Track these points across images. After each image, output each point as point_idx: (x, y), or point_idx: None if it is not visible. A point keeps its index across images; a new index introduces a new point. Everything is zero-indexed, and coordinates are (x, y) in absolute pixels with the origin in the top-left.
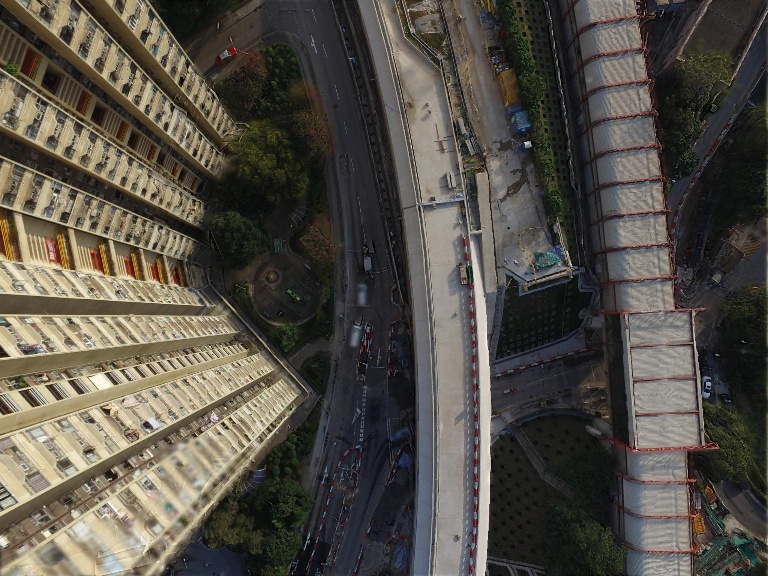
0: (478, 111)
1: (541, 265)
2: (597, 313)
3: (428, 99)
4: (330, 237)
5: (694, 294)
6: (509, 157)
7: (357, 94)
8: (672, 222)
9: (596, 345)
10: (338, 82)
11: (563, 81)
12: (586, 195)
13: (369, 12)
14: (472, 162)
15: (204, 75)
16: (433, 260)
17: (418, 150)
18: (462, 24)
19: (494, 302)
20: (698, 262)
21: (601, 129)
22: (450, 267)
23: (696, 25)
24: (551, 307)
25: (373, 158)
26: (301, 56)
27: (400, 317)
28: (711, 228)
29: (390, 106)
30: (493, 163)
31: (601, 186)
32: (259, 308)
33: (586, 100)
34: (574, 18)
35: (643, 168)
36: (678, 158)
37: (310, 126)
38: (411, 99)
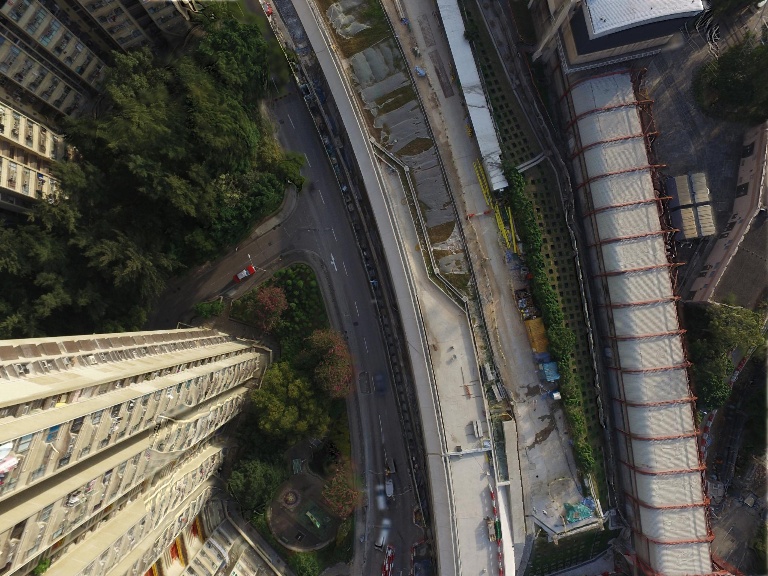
0: (504, 355)
1: (572, 520)
2: (628, 554)
3: (453, 341)
4: (350, 457)
5: (726, 513)
6: (537, 403)
7: (378, 317)
8: (702, 438)
9: (626, 570)
10: (358, 299)
11: (590, 312)
12: (615, 429)
13: (392, 249)
14: (499, 407)
15: (222, 291)
16: (460, 513)
17: (443, 395)
18: (487, 264)
19: (522, 549)
20: (729, 478)
21: (632, 379)
22: (477, 520)
23: (727, 264)
24: (580, 544)
25: (395, 381)
26: (321, 274)
27: (422, 538)
28: (742, 442)
29: (414, 346)
30: (520, 409)
31: (632, 436)
32: (277, 532)
33: (615, 342)
34: (602, 257)
35: (676, 423)
36: (710, 394)
37: (333, 381)
38: (436, 341)
